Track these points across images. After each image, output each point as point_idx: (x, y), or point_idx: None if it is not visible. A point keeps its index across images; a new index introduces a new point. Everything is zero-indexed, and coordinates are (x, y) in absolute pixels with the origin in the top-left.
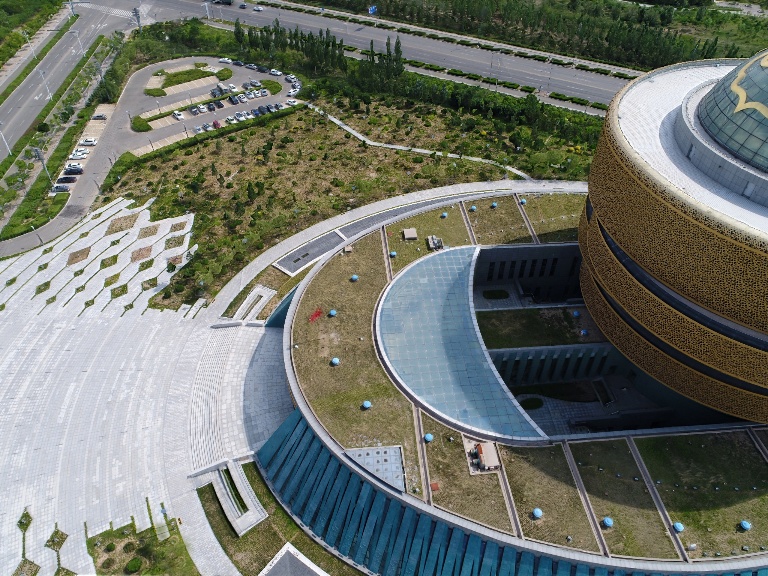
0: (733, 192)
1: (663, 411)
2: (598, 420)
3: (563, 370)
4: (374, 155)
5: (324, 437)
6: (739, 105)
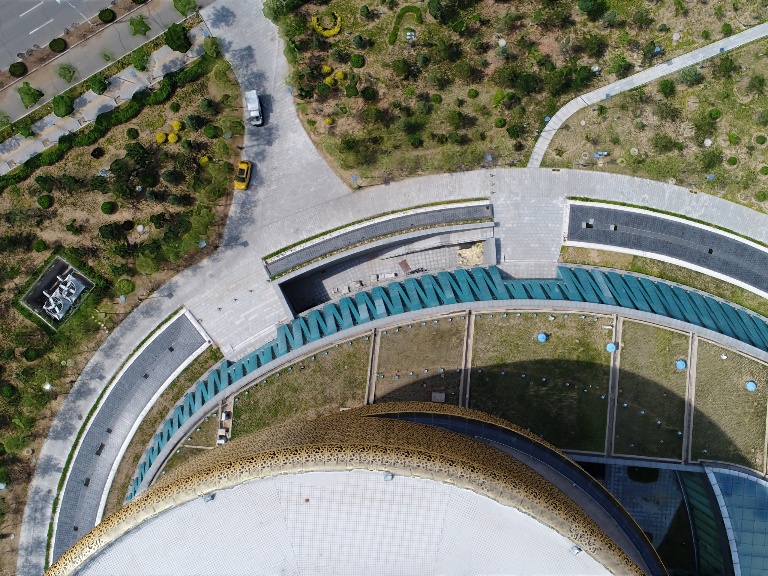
0: None
1: None
2: None
3: None
4: None
5: None
6: None
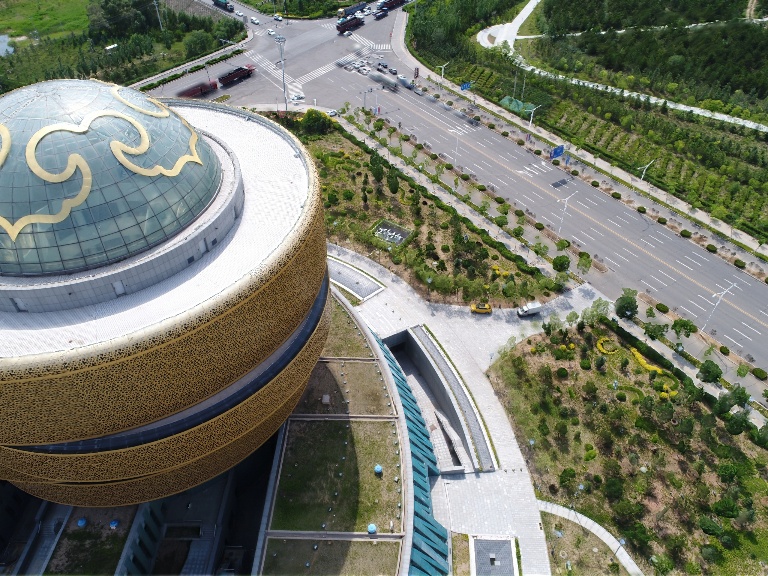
0: (108, 302)
1: (232, 479)
2: (216, 553)
3: (140, 570)
4: None
5: None
6: (9, 231)
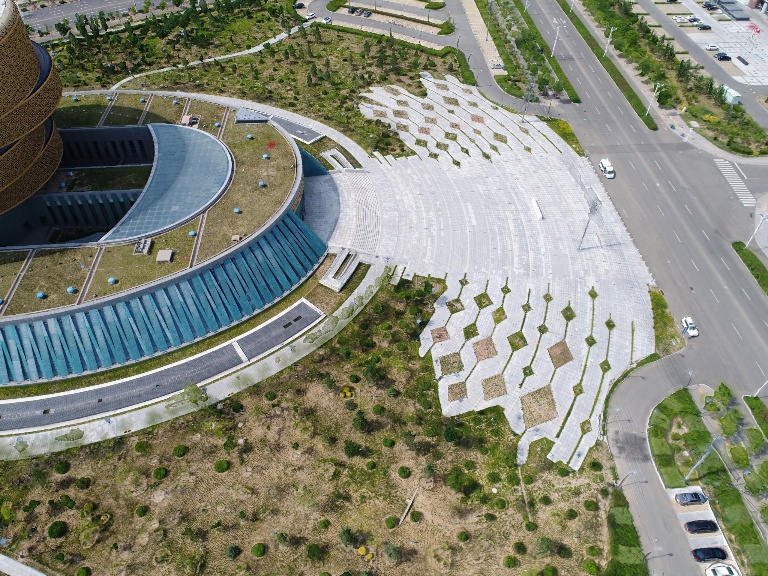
0: None
1: None
2: None
3: None
4: (135, 569)
5: (278, 126)
6: None
